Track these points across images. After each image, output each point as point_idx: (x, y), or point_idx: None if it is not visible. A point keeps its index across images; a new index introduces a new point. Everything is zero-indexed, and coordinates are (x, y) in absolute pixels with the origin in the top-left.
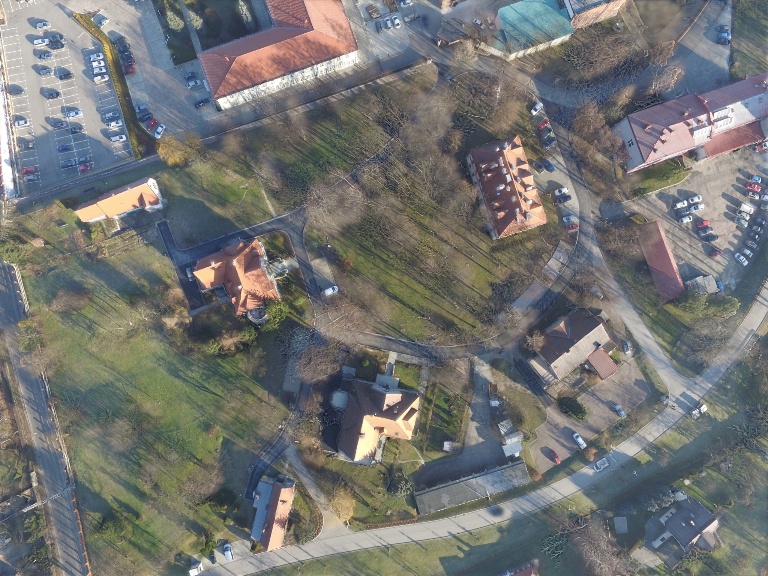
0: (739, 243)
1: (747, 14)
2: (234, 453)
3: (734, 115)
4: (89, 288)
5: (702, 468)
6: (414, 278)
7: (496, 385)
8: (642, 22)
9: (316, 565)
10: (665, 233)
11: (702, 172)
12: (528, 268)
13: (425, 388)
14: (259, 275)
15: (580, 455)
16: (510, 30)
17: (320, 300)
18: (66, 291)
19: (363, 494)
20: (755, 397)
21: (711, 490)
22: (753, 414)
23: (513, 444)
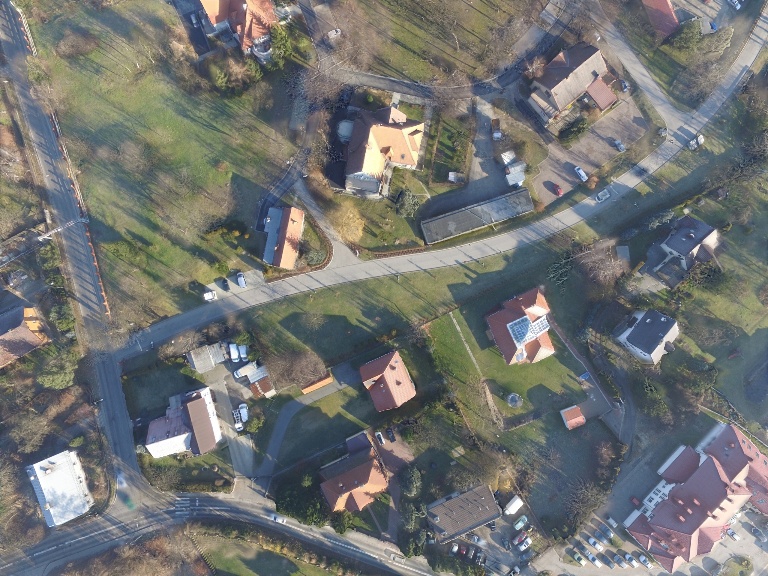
0: None
1: None
2: (244, 187)
3: None
4: (95, 34)
5: (700, 197)
6: (415, 24)
7: (498, 119)
8: None
9: (327, 292)
10: None
11: None
12: (526, 13)
13: (429, 126)
14: (263, 0)
15: (582, 187)
16: None
17: (323, 44)
18: (73, 32)
19: (371, 226)
20: (750, 127)
21: (710, 218)
22: (749, 148)
23: (516, 174)
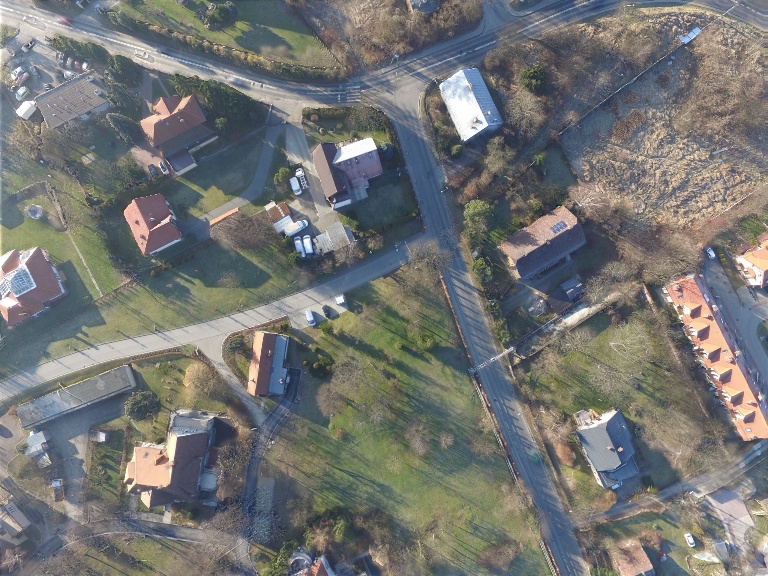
0: None
1: None
2: (316, 413)
3: None
4: (482, 568)
5: None
6: None
7: None
8: None
9: (225, 310)
10: None
11: None
12: None
13: None
14: None
15: None
16: None
17: (246, 572)
18: None
19: None
20: None
21: None
22: None
23: (36, 444)
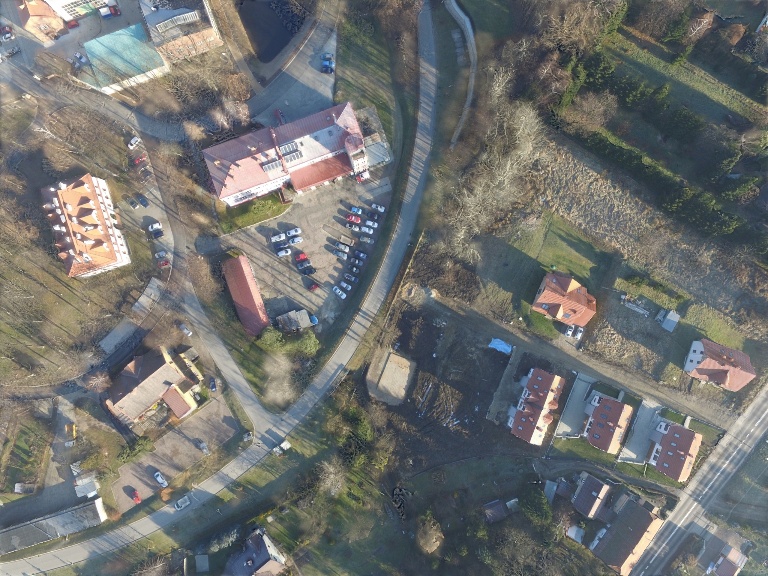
0: (339, 276)
1: (352, 41)
2: None
3: (305, 149)
4: None
5: (285, 505)
6: (1, 318)
7: (72, 425)
8: (253, 51)
9: None
10: (264, 267)
11: (303, 204)
12: (118, 306)
13: (6, 429)
14: None
15: None
16: (98, 64)
17: None
18: None
19: None
20: None
21: (293, 527)
22: (344, 449)
23: (86, 485)
